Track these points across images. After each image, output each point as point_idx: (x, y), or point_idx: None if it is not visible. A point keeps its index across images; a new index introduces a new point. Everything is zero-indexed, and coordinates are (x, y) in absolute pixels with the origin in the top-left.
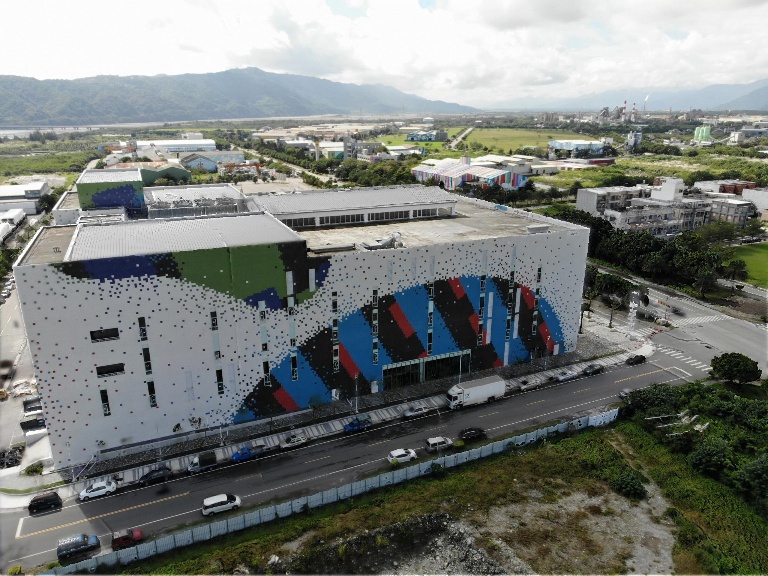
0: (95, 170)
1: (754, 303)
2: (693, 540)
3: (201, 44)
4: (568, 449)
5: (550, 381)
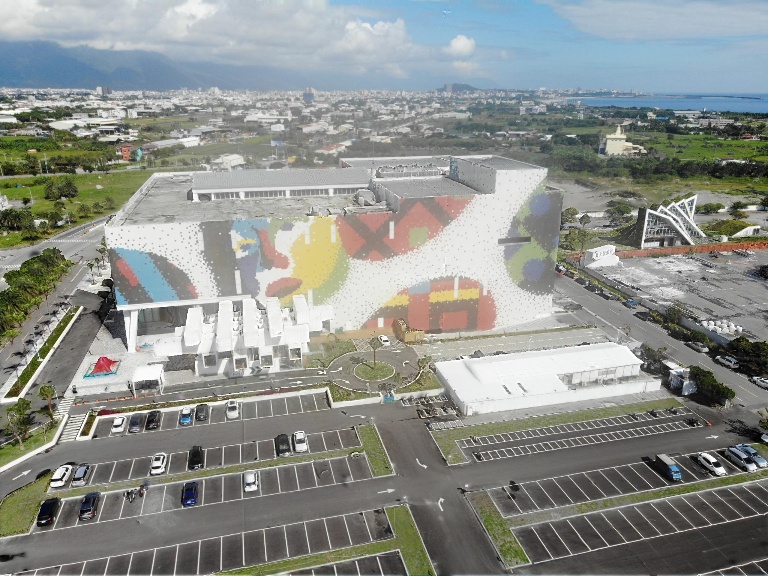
0: (538, 169)
1: None
2: None
3: (430, 7)
4: None
5: None
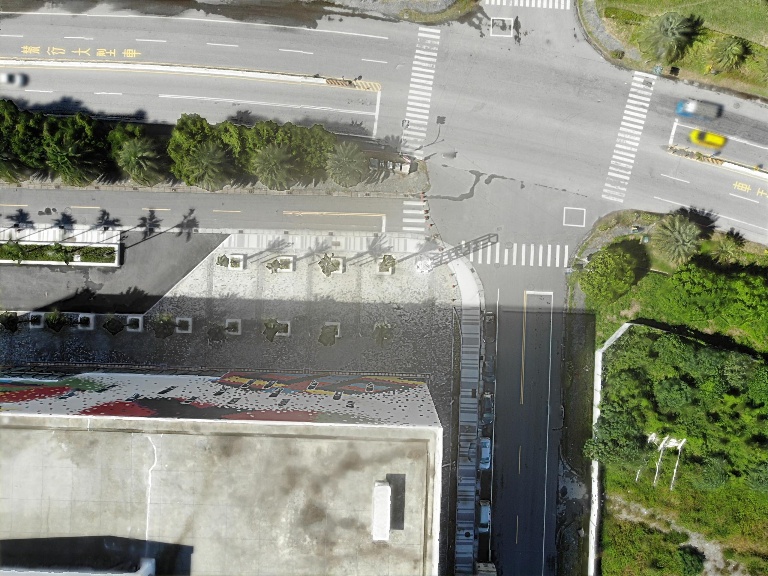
0: None
1: None
2: (763, 572)
3: None
4: (616, 572)
5: (481, 477)
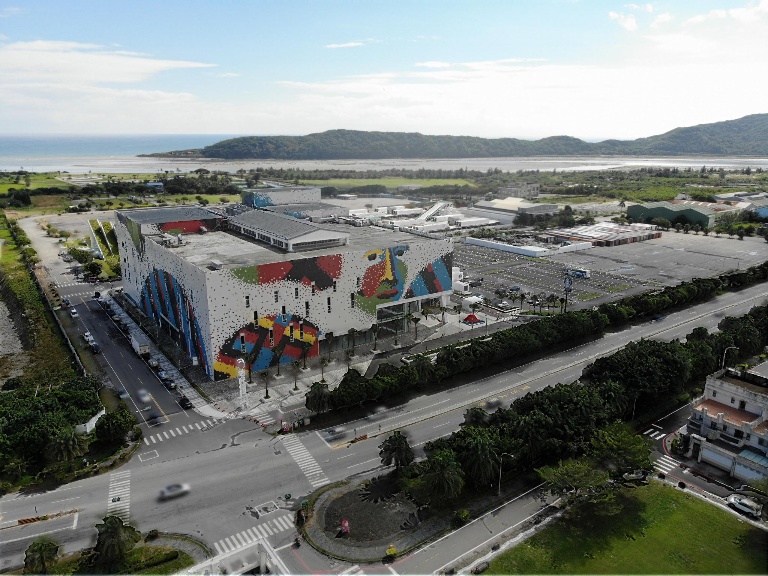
0: None
1: (383, 517)
2: None
3: (362, 109)
4: None
5: None
